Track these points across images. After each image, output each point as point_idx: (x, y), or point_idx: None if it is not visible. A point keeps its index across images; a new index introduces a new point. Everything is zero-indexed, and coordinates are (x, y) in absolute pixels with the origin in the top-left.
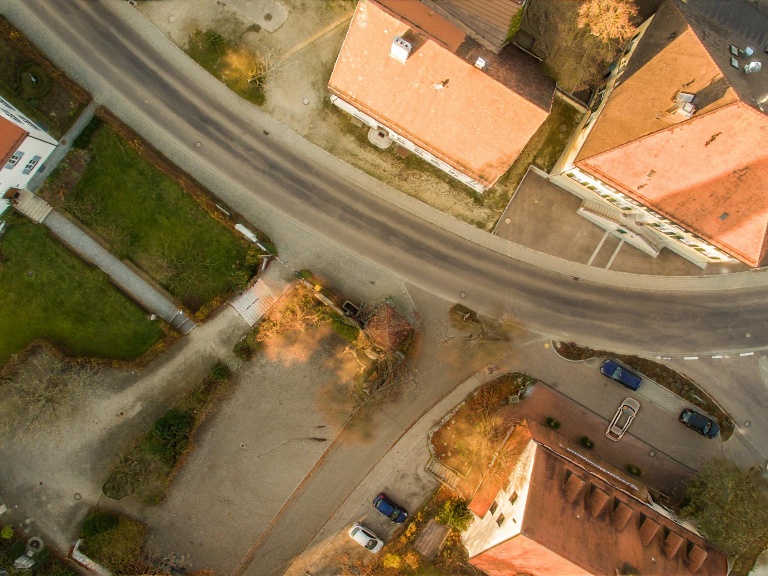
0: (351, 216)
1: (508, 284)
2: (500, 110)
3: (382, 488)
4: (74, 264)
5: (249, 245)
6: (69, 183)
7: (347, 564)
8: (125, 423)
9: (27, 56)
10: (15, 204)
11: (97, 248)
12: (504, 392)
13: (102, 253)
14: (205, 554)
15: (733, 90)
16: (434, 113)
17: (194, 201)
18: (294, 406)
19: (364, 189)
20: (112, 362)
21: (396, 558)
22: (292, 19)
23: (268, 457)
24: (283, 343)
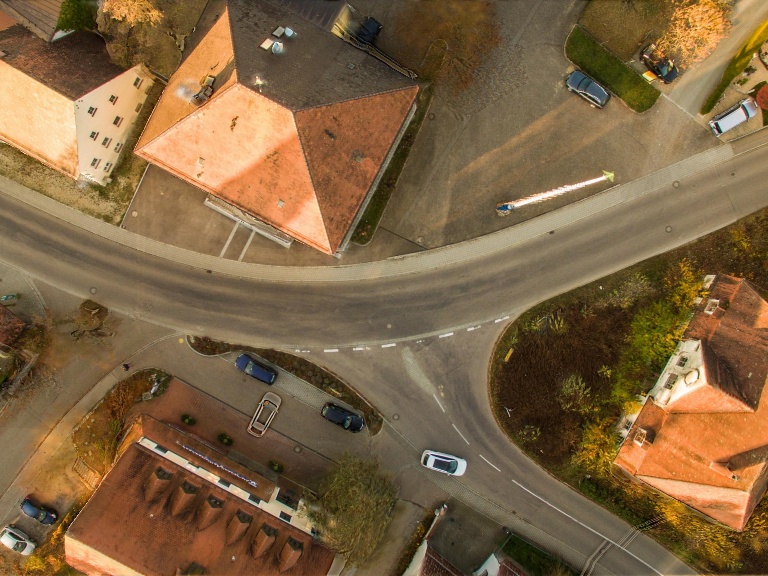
0: None
1: (139, 278)
2: (37, 99)
3: (32, 489)
4: None
5: None
6: None
7: (4, 567)
8: None
9: None
10: None
11: None
12: (139, 389)
13: None
14: None
15: (236, 72)
16: None
17: None
18: None
19: None
20: None
21: (37, 560)
22: None
23: None
24: None
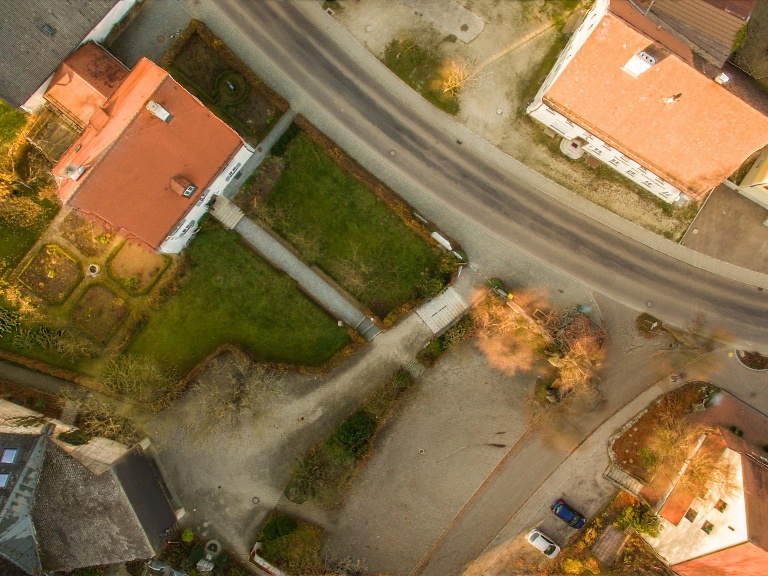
0: (541, 225)
1: (694, 294)
2: (731, 124)
3: (560, 494)
4: (263, 270)
5: (441, 253)
6: (262, 190)
7: (522, 569)
8: (305, 428)
9: (226, 64)
10: (212, 210)
11: (286, 254)
12: (688, 400)
13: (291, 259)
14: (381, 558)
15: None
16: (655, 126)
17: (387, 209)
18: (474, 412)
19: (554, 199)
20: (299, 367)
21: (578, 564)
22: (488, 30)
23: (447, 463)
24: (466, 350)
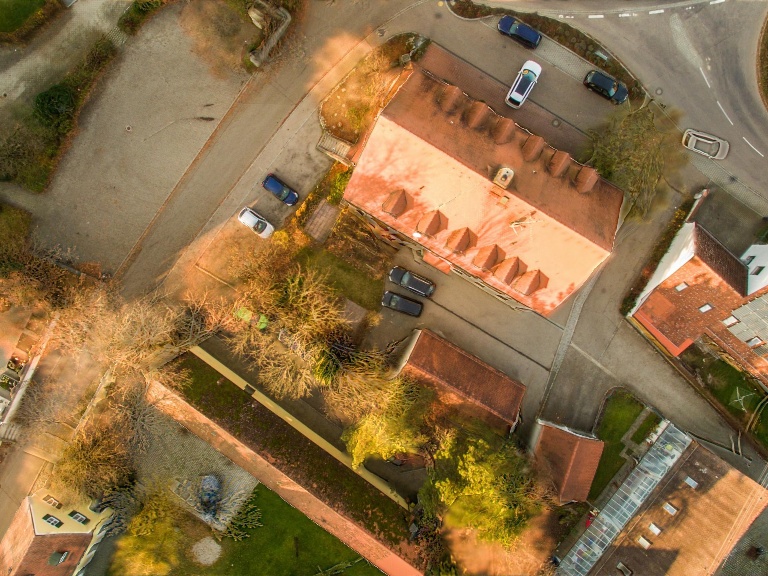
0: None
1: None
2: None
3: (272, 170)
4: None
5: None
6: None
7: (238, 254)
8: (9, 105)
9: None
10: None
11: None
12: (396, 54)
13: None
14: (92, 246)
15: None
16: None
17: None
18: (181, 83)
19: None
20: None
21: (283, 233)
22: None
23: (155, 140)
24: (168, 15)
